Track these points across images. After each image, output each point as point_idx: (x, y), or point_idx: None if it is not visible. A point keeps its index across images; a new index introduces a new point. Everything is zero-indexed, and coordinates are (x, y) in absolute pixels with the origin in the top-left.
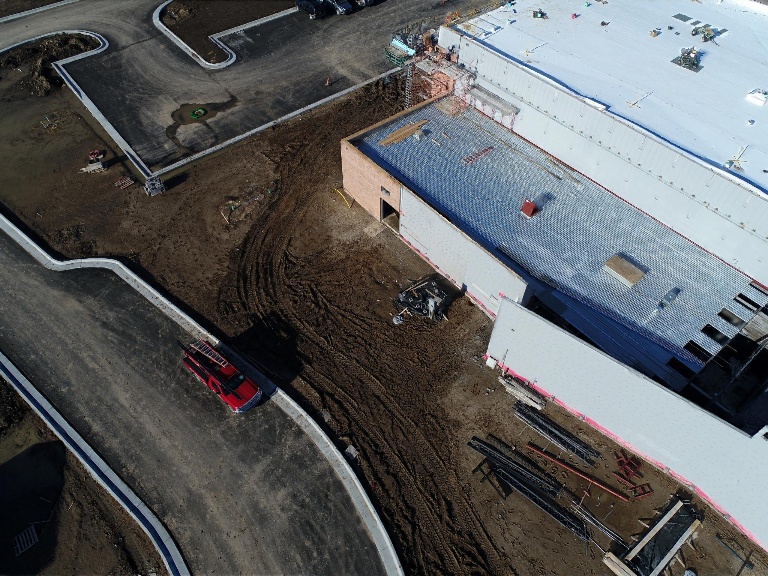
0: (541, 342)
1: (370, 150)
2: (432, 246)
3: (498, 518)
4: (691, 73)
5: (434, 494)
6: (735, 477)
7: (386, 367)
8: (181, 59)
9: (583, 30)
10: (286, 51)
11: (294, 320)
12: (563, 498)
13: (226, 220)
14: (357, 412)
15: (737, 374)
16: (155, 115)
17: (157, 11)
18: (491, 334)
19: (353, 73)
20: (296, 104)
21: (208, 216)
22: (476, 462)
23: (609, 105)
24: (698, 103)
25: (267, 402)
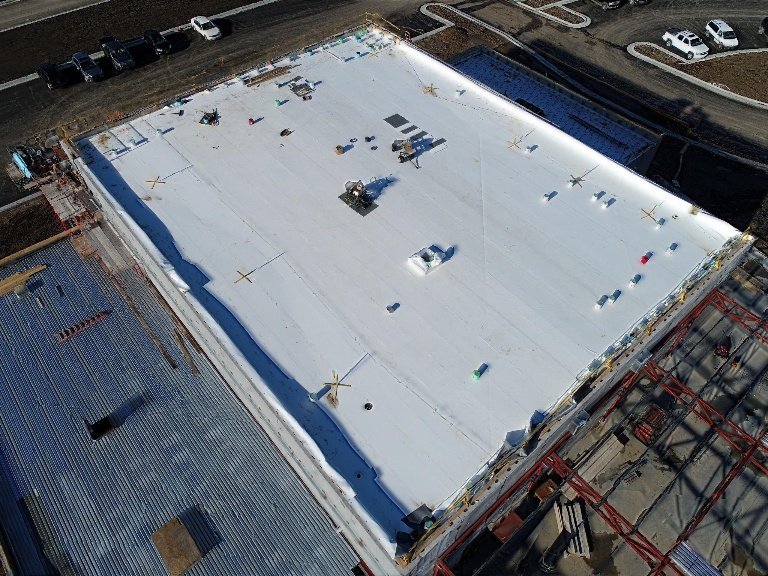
0: None
1: None
2: None
3: None
4: (355, 217)
5: None
6: None
7: None
8: None
9: (252, 144)
10: None
11: None
12: None
13: None
14: None
15: None
16: None
17: None
18: None
19: None
20: None
21: None
22: None
23: (209, 278)
24: (337, 272)
25: None
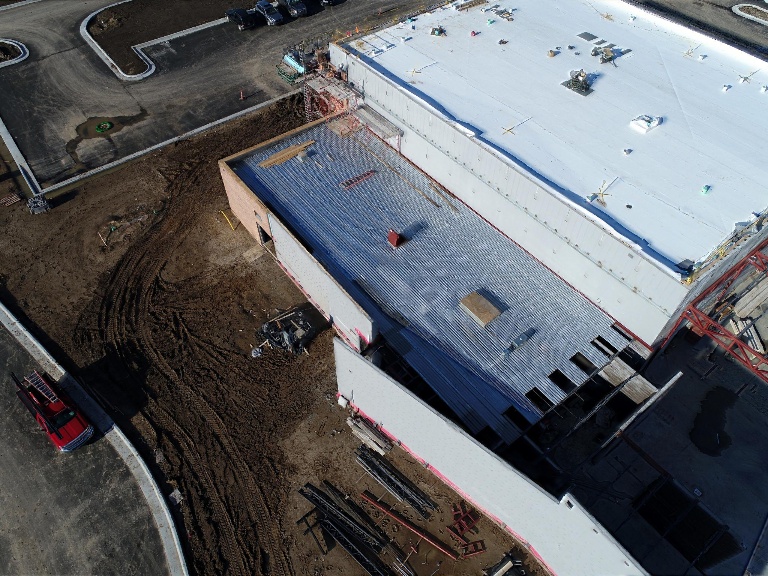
0: (374, 386)
1: (248, 172)
2: (301, 274)
3: (314, 575)
4: (579, 97)
5: (252, 546)
6: (556, 541)
7: (233, 404)
8: (99, 70)
9: (479, 49)
10: (208, 63)
11: (149, 350)
12: (388, 554)
13: (103, 241)
14: (192, 453)
15: (576, 426)
16: (59, 128)
17: (86, 20)
18: (336, 373)
19: (271, 87)
20: (205, 119)
21: (87, 236)
22: (304, 512)
23: (482, 131)
24: (577, 130)
25: (100, 440)
